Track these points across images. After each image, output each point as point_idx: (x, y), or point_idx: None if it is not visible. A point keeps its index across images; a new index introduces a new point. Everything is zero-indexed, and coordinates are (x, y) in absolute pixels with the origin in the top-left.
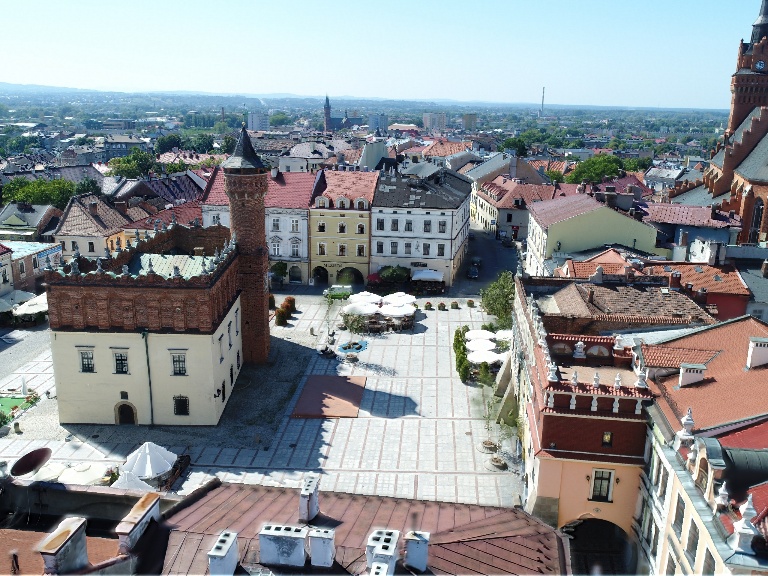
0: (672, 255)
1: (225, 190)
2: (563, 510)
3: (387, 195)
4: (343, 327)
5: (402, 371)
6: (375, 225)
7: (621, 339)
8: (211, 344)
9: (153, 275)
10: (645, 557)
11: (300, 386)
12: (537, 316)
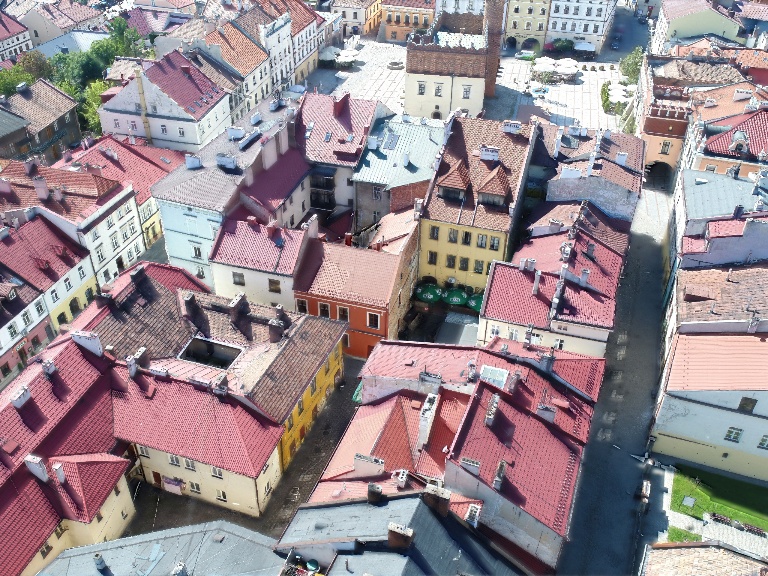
0: (746, 42)
1: None
2: (648, 157)
3: None
4: (533, 79)
5: (571, 105)
6: (553, 9)
7: (687, 88)
8: (484, 83)
9: (461, 47)
10: (677, 174)
11: (516, 110)
12: (651, 76)
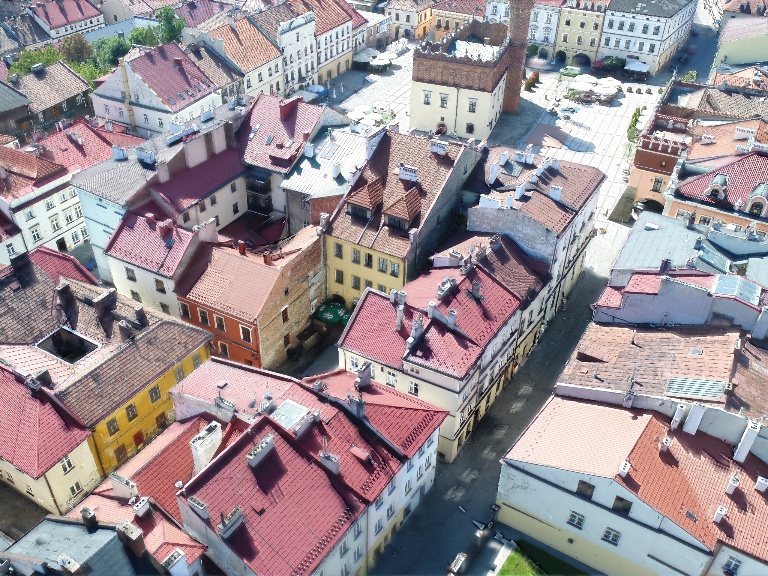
0: None
1: (509, 5)
2: (639, 194)
3: (621, 1)
4: (567, 97)
5: (595, 128)
6: (607, 24)
7: (692, 121)
8: (490, 98)
9: (467, 58)
10: None
11: (533, 128)
12: None
